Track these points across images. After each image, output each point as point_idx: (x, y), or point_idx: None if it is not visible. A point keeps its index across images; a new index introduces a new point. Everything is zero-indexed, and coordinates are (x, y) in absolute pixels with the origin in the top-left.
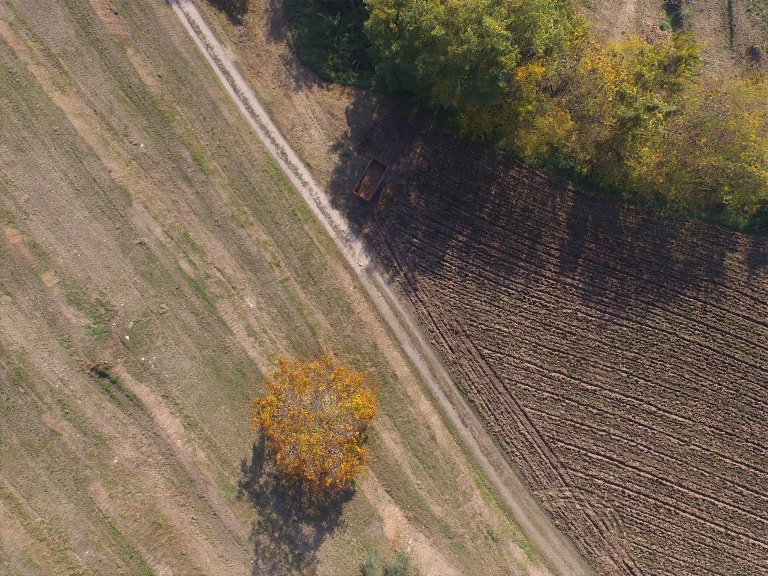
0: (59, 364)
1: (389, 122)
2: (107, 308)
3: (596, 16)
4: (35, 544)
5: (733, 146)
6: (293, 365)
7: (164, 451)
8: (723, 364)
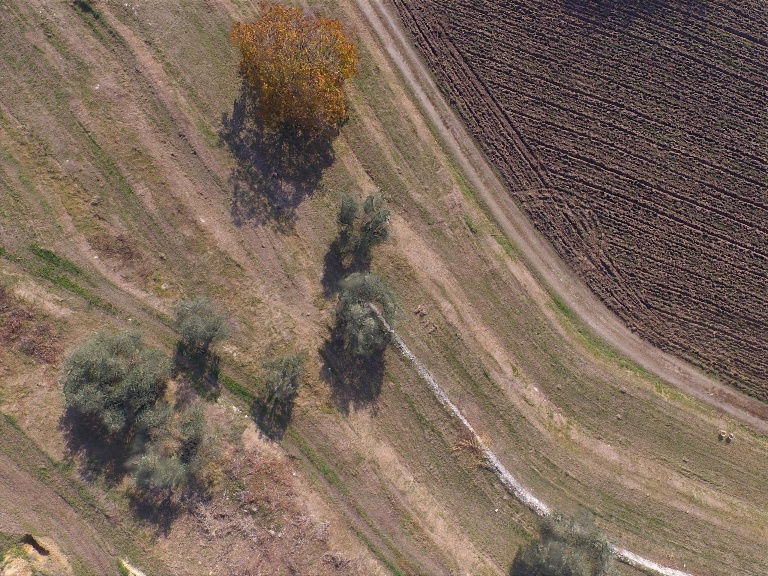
0: None
1: None
2: None
3: None
4: (16, 145)
5: None
6: None
7: (145, 88)
8: (704, 73)
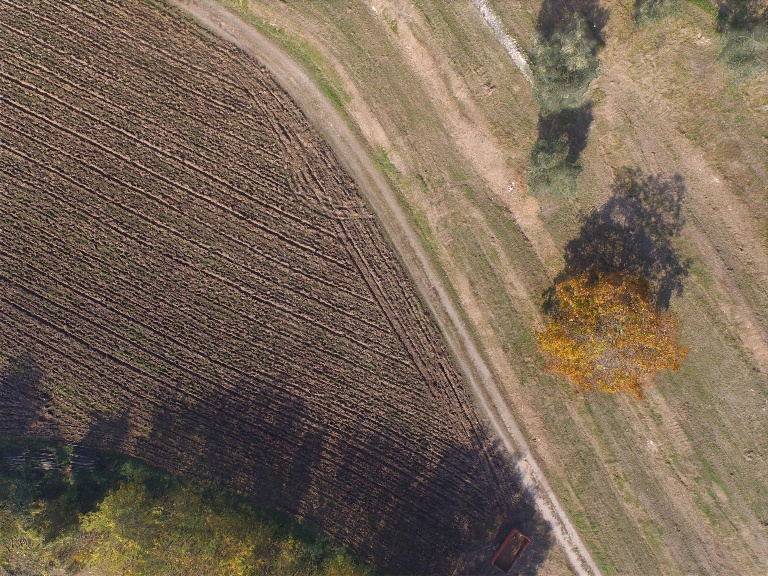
0: None
1: None
2: None
3: None
4: None
5: (152, 572)
6: None
7: (765, 319)
8: (166, 326)
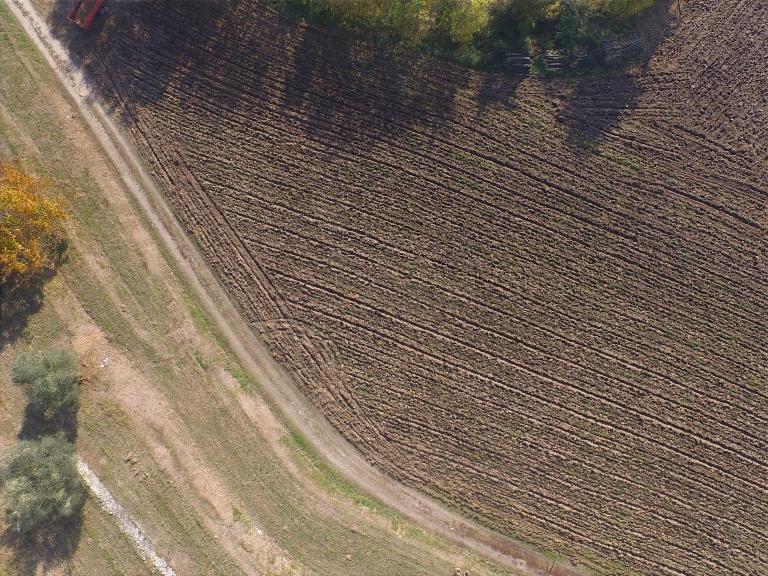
0: None
1: None
2: None
3: None
4: None
5: None
6: None
7: None
8: (448, 198)
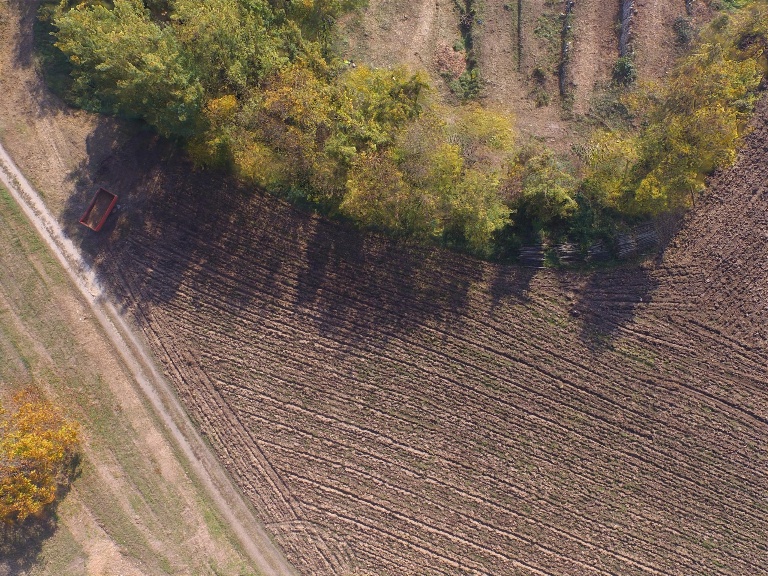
0: None
1: (129, 150)
2: None
3: (390, 37)
4: None
5: (432, 179)
6: (2, 399)
7: None
8: (462, 396)
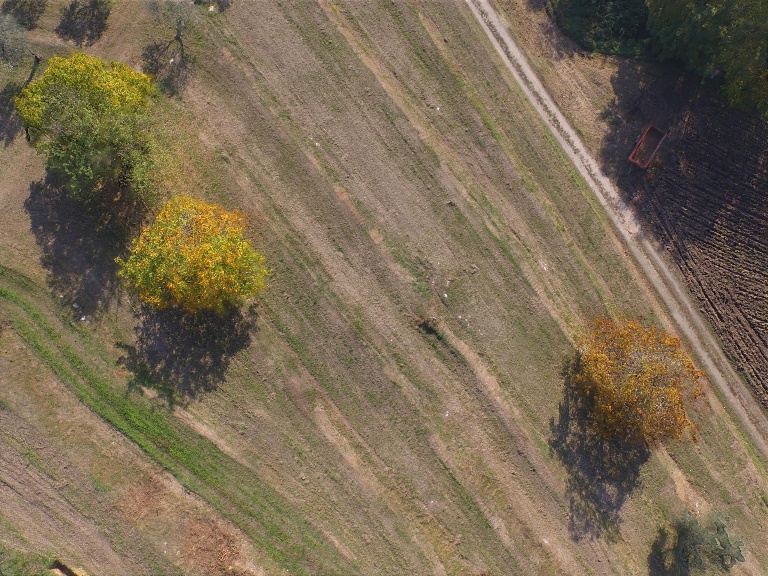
0: (391, 319)
1: (656, 91)
2: (426, 266)
3: None
4: (387, 492)
5: None
6: (584, 328)
7: (486, 407)
8: None
